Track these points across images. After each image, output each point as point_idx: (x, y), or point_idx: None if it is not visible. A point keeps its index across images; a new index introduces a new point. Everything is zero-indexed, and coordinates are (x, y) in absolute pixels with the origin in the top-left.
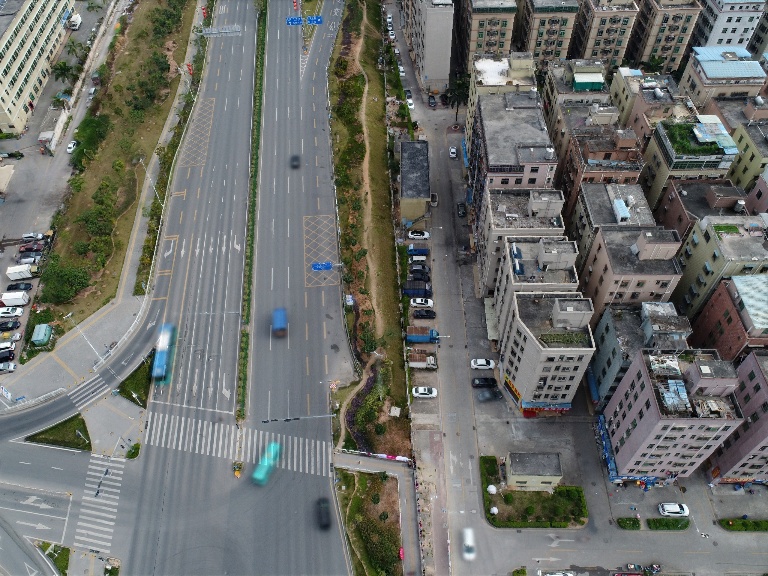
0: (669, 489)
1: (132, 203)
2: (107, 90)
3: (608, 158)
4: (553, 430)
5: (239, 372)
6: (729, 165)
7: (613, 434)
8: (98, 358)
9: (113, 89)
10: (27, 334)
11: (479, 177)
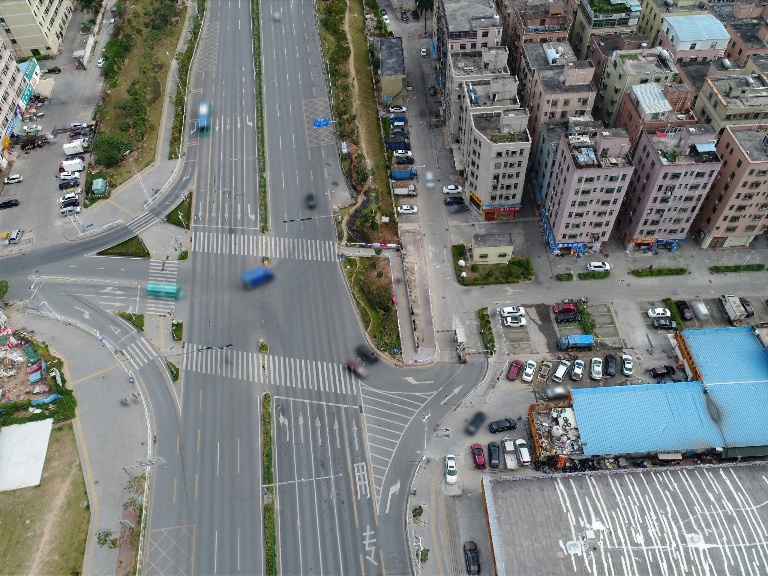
0: (596, 256)
1: (158, 99)
2: (125, 20)
3: (543, 24)
4: (508, 227)
5: (260, 202)
6: (636, 22)
7: (551, 216)
8: (147, 199)
9: None
10: (87, 188)
11: (443, 51)
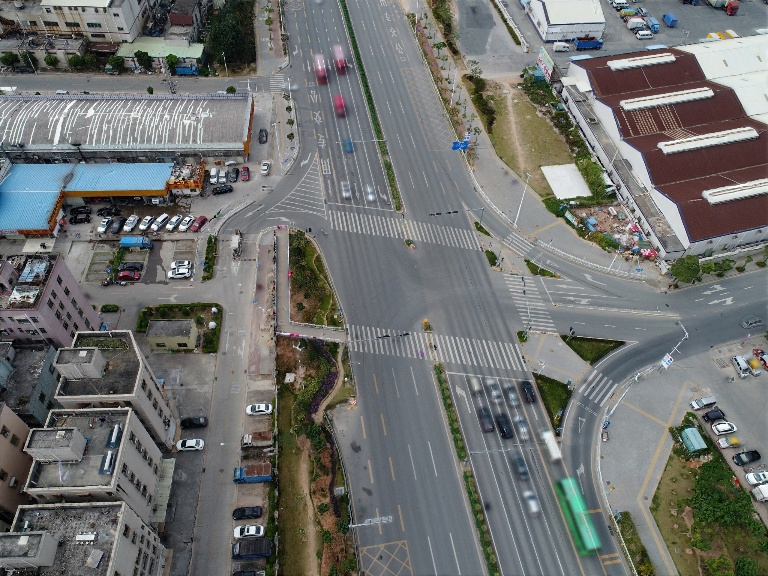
0: None
1: None
2: None
3: None
4: None
5: None
6: None
7: None
8: None
9: None
10: (712, 444)
11: None
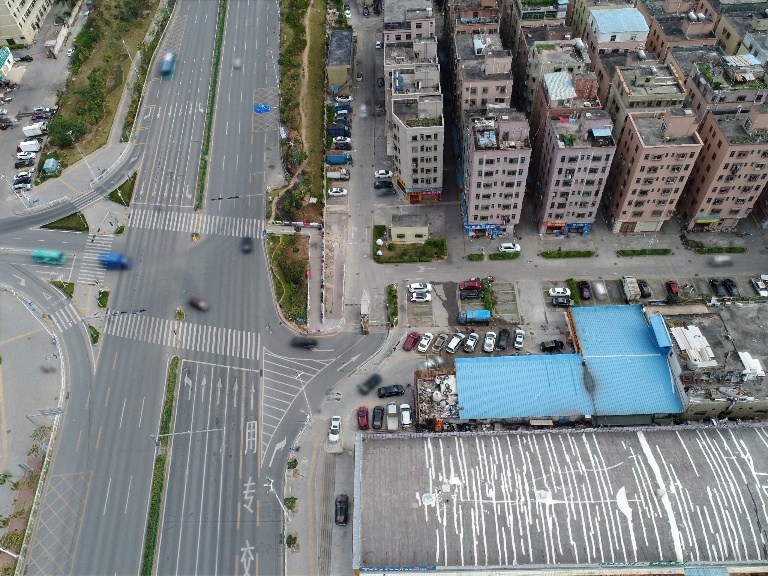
0: (509, 238)
1: (119, 86)
2: None
3: (476, 17)
4: (431, 210)
5: None
6: None
7: None
8: (93, 178)
9: (104, 11)
10: (40, 167)
11: None
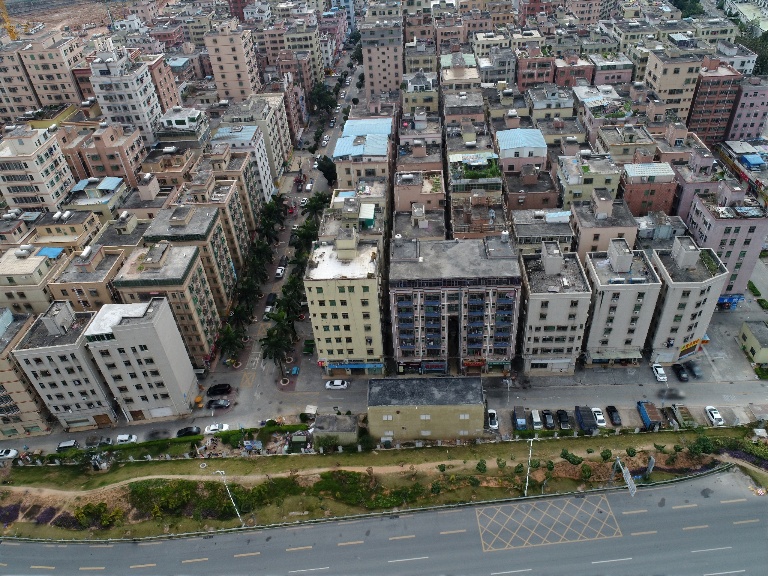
0: None
1: None
2: None
3: None
4: None
5: None
6: None
7: None
8: None
9: None
10: None
11: (483, 314)
